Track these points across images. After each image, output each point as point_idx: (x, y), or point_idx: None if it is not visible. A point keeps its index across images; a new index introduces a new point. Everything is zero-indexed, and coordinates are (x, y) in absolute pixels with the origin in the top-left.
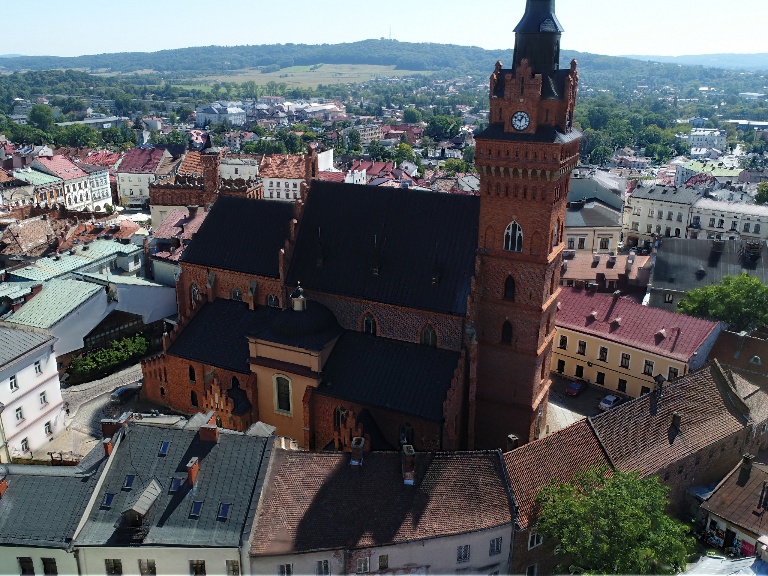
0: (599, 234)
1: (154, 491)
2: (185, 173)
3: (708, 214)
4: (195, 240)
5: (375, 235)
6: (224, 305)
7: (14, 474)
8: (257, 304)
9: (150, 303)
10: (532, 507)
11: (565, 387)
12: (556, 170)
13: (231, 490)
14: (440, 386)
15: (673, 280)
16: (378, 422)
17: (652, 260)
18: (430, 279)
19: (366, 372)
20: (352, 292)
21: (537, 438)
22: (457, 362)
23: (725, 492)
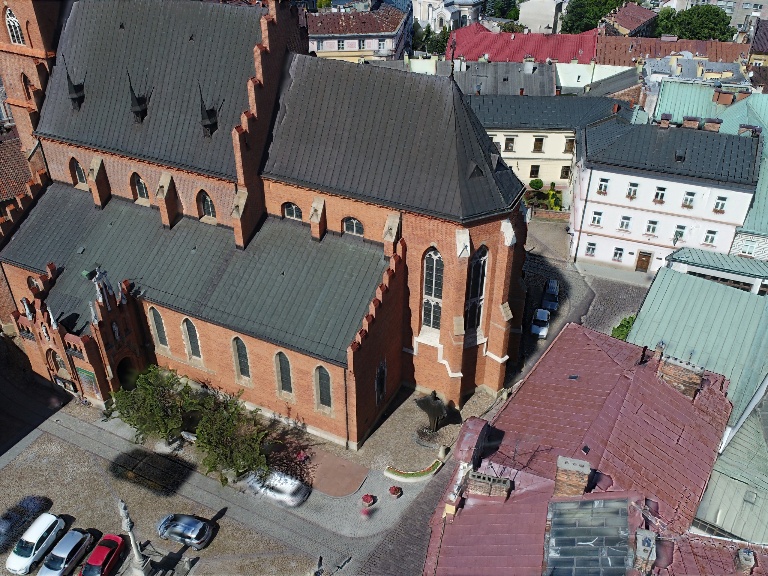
0: None
1: None
2: None
3: None
4: None
5: None
6: None
7: (478, 95)
8: None
9: None
10: None
11: None
12: None
13: None
14: None
15: None
16: None
17: None
18: None
19: None
20: None
21: None
22: None
23: None
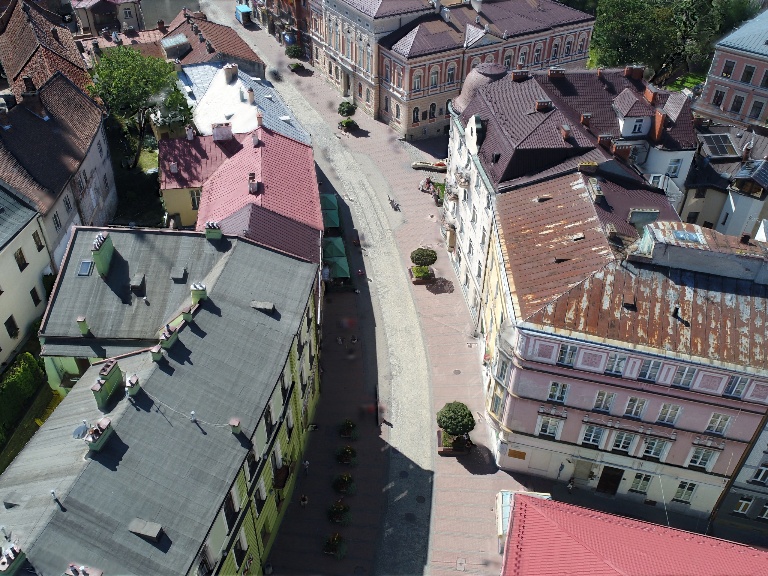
0: None
1: None
2: None
3: None
4: None
5: None
6: None
7: None
8: None
9: None
10: None
11: None
12: None
13: None
14: None
15: None
16: None
17: None
18: None
19: None
20: None
21: None
22: None
23: None
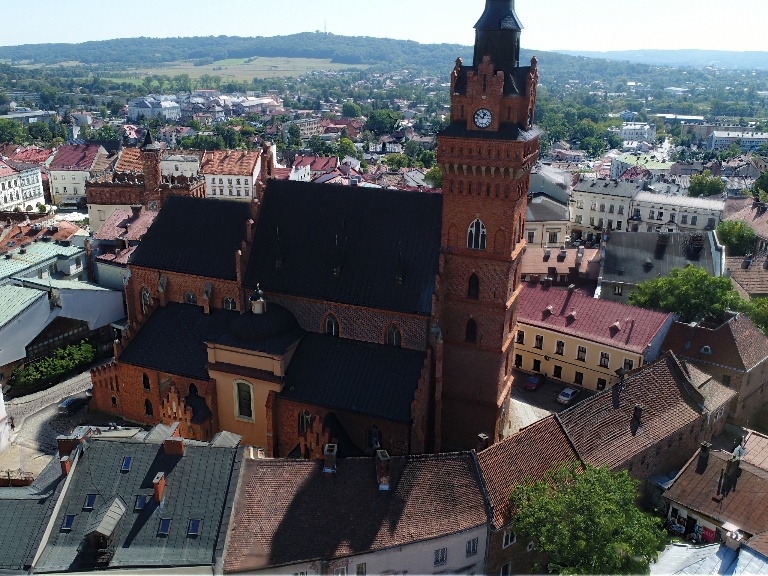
0: (548, 228)
1: (118, 510)
2: (123, 170)
3: (648, 207)
4: (144, 242)
5: (336, 235)
6: (177, 309)
7: None
8: (213, 307)
9: (96, 308)
10: (506, 506)
11: (523, 381)
12: (519, 168)
13: (201, 505)
14: (406, 387)
15: (622, 273)
16: (344, 425)
17: (602, 253)
18: (393, 278)
19: (330, 375)
20: (313, 293)
21: (501, 434)
22: (423, 362)
23: (685, 480)
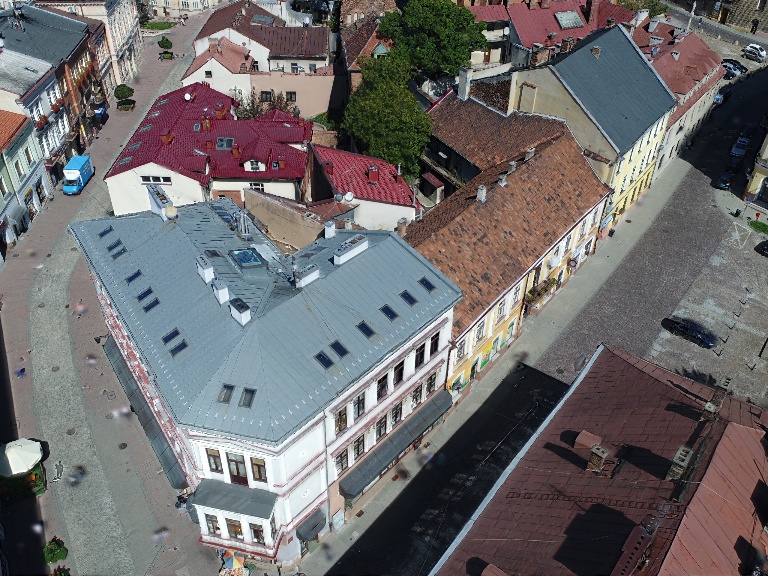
0: None
1: None
2: None
3: None
4: None
5: None
6: None
7: None
8: None
9: None
10: None
11: None
12: None
13: None
14: None
15: None
16: None
17: None
18: None
19: None
20: None
21: None
22: None
23: None
